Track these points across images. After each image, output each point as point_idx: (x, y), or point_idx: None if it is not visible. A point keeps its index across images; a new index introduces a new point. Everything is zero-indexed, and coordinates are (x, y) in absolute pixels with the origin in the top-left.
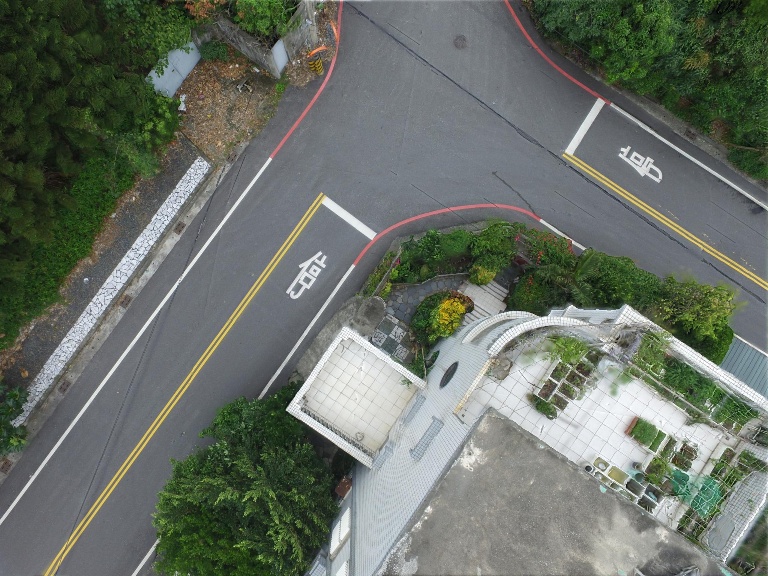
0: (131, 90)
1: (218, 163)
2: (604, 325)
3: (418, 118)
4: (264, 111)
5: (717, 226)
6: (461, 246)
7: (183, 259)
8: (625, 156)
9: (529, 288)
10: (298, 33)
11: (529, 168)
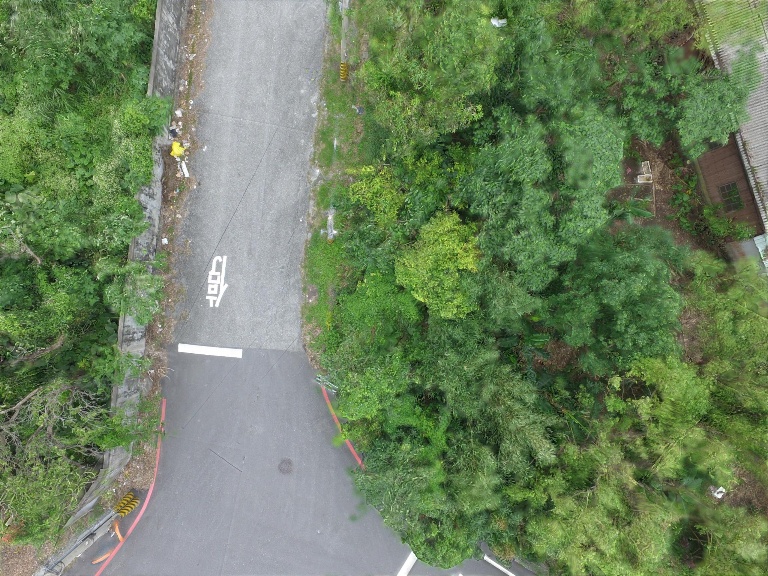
0: None
1: None
2: None
3: (237, 552)
4: None
5: None
6: None
7: None
8: None
9: None
10: (104, 484)
11: None
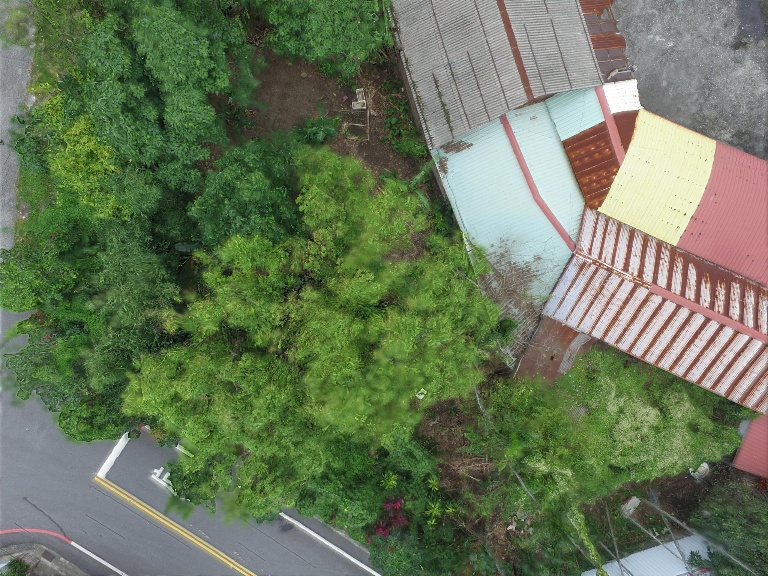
0: None
1: None
2: None
3: None
4: None
5: (248, 544)
6: None
7: None
8: (158, 477)
9: None
10: None
11: (60, 492)
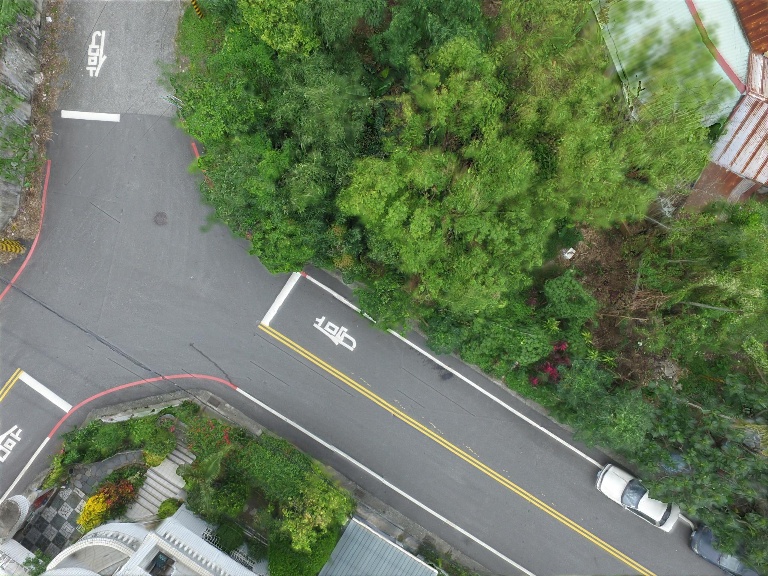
0: None
1: None
2: None
3: (116, 294)
4: None
5: (408, 392)
6: (109, 443)
7: None
8: (320, 326)
9: None
10: None
11: (225, 339)
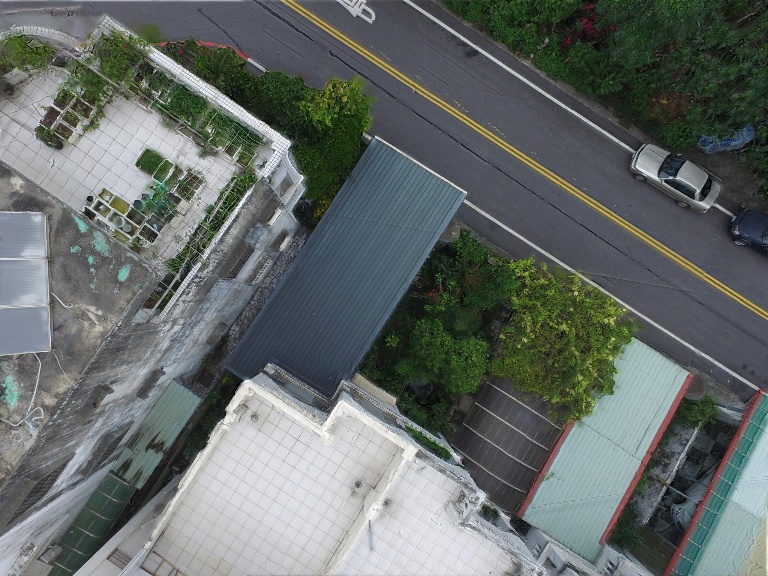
0: None
1: None
2: None
3: None
4: None
5: (430, 68)
6: None
7: None
8: None
9: None
10: None
11: (236, 6)
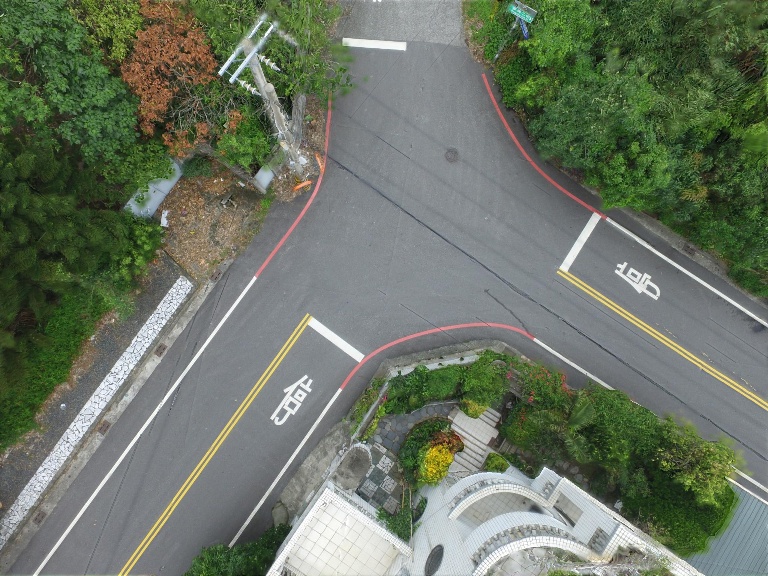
0: (107, 231)
1: (201, 282)
2: (596, 548)
3: (408, 235)
4: (249, 227)
5: (717, 345)
6: (450, 388)
7: (164, 383)
8: (621, 272)
9: (521, 424)
10: (284, 153)
11: (522, 285)
